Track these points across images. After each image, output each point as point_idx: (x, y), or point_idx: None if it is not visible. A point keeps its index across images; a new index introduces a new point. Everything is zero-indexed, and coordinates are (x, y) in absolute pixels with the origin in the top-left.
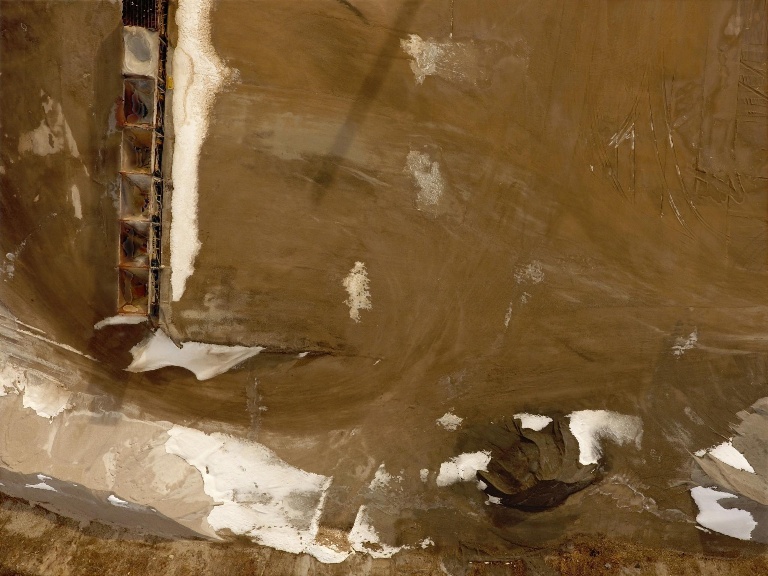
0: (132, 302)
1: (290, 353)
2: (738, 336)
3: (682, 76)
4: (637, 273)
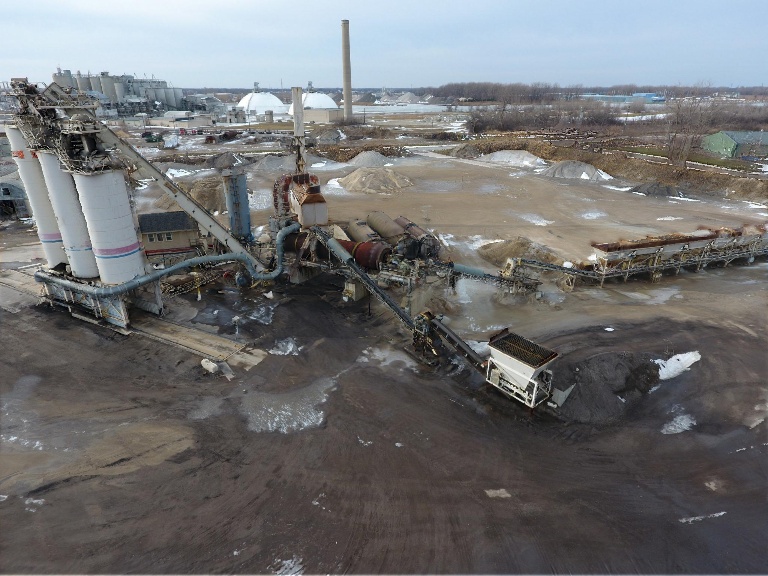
0: None
1: None
2: None
3: None
4: None
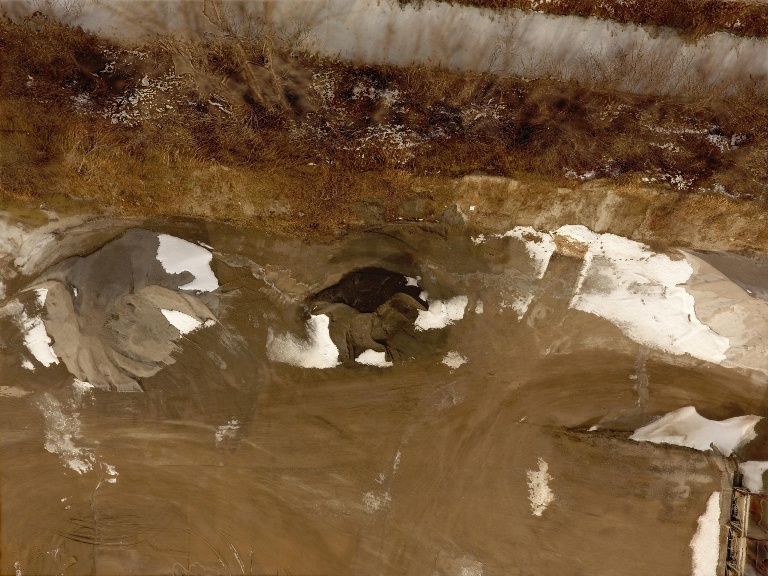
0: (761, 499)
1: (606, 430)
2: (176, 437)
3: None
4: (274, 500)
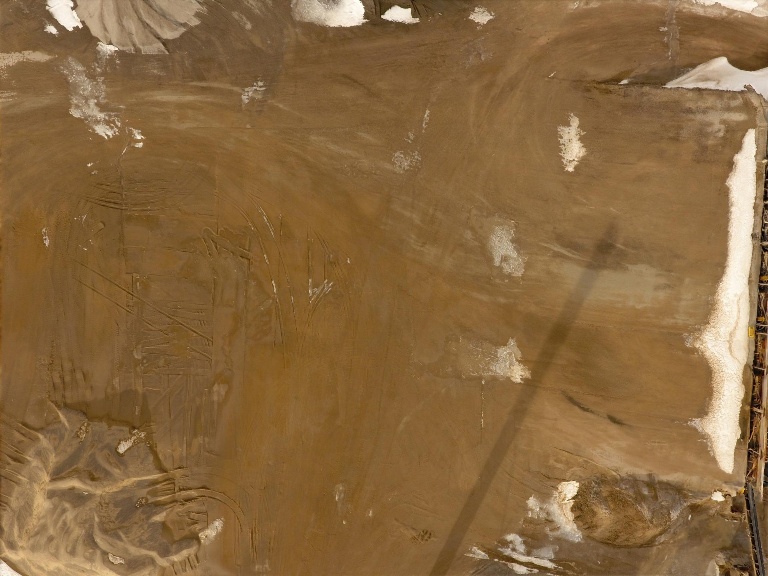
0: None
1: (637, 84)
2: (202, 100)
3: (266, 346)
4: (303, 161)
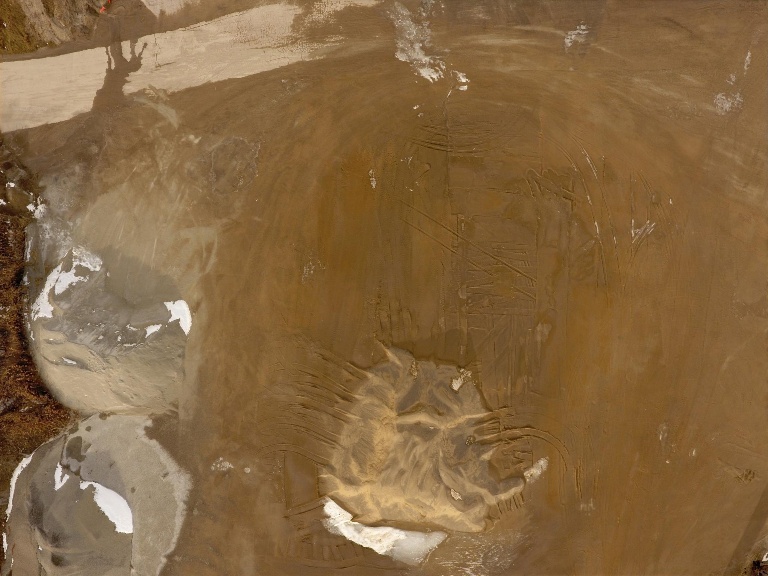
0: None
1: None
2: (526, 43)
3: (589, 286)
4: (626, 103)
